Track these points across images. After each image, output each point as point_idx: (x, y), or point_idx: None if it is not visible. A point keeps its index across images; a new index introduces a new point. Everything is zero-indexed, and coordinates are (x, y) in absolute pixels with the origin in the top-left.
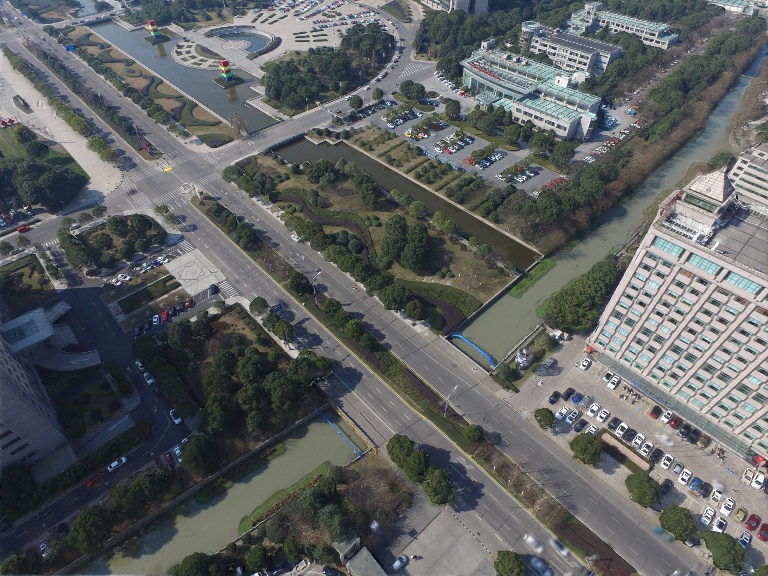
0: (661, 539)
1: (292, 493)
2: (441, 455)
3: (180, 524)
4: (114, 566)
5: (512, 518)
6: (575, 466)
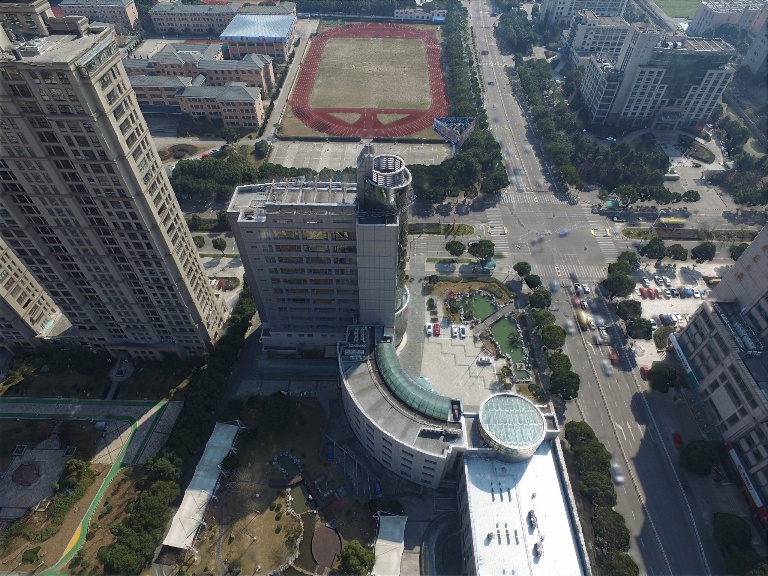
0: (666, 258)
1: (762, 180)
2: (763, 222)
3: (761, 154)
4: (749, 138)
5: (710, 223)
6: (728, 261)
